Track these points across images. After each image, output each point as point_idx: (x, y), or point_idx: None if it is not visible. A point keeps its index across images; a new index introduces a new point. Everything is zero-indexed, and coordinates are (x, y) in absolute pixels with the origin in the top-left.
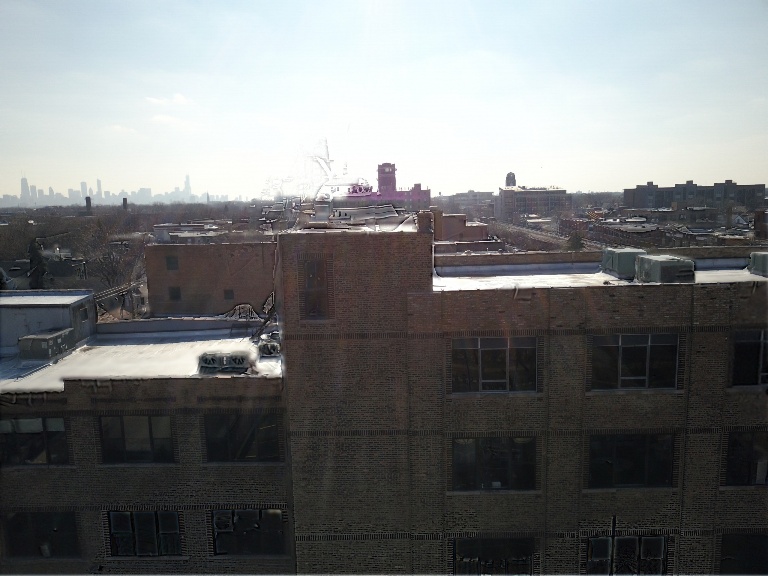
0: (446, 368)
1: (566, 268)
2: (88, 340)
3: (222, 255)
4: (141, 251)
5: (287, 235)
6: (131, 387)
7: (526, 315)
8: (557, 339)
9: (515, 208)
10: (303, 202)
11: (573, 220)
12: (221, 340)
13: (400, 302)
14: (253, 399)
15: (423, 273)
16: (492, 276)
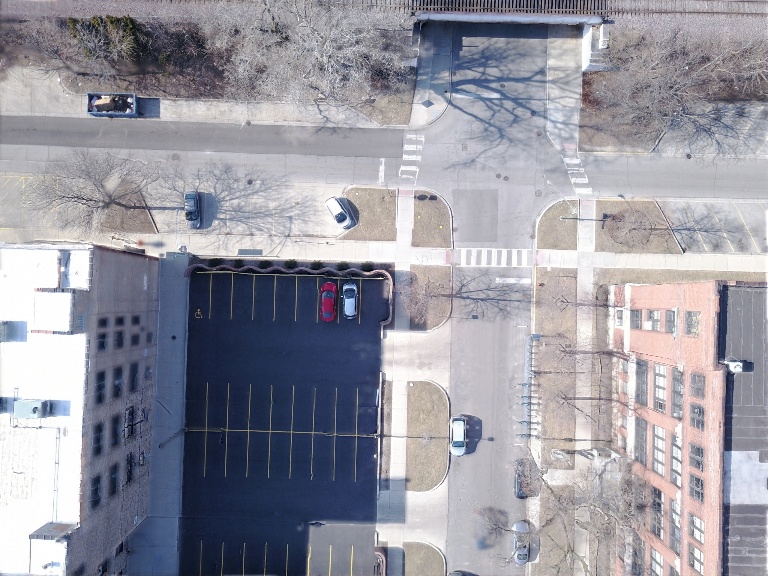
0: None
1: None
2: None
3: None
4: None
5: None
6: None
7: None
8: None
9: None
10: None
11: None
12: None
13: None
14: None
15: None
16: None
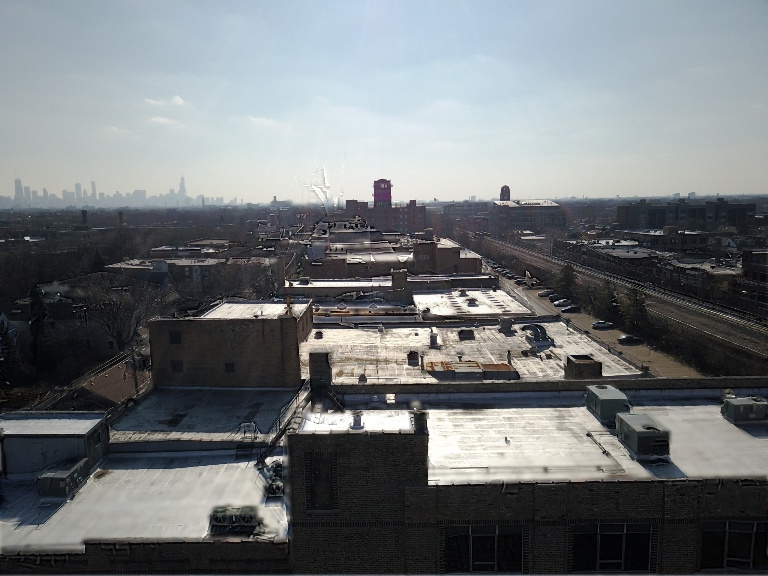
0: (440, 555)
1: (553, 397)
2: (101, 462)
3: (224, 330)
4: (141, 296)
5: (295, 435)
6: (148, 550)
7: (513, 507)
8: (541, 529)
9: (509, 229)
10: (300, 231)
11: (566, 242)
12: (227, 464)
13: (398, 494)
14: (261, 561)
15: (419, 469)
16: (483, 409)
